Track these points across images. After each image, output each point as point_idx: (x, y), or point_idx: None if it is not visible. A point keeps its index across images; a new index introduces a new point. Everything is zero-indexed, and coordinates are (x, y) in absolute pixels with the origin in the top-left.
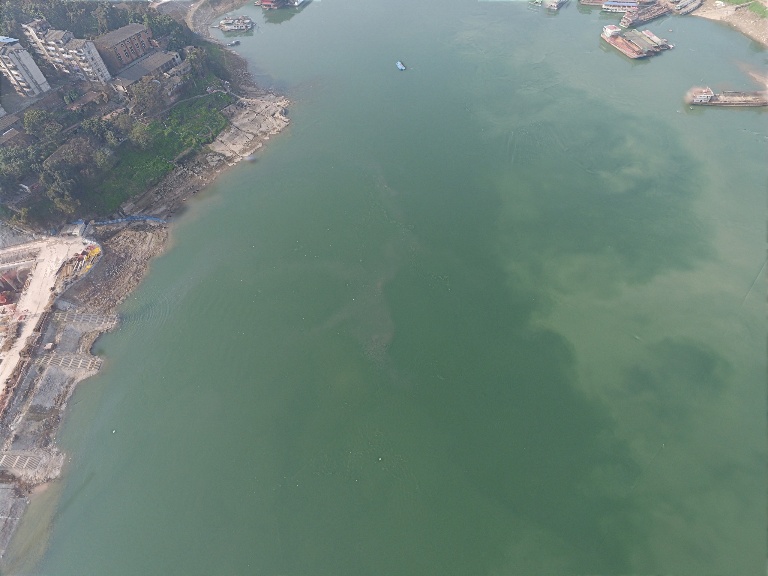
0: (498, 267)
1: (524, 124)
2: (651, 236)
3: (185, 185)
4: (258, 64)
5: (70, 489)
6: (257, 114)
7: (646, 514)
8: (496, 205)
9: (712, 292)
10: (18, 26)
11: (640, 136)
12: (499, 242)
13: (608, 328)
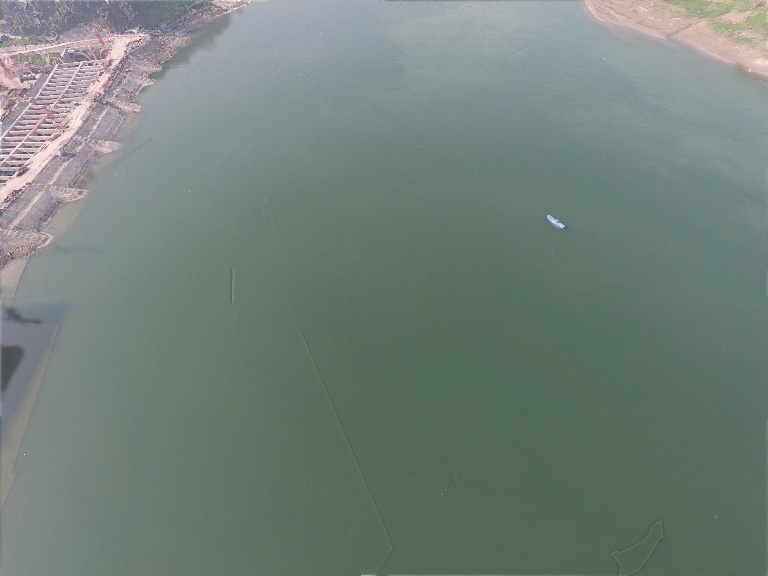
0: None
1: None
2: (470, 39)
3: (197, 20)
4: None
5: (145, 116)
6: None
7: None
8: (384, 25)
9: (491, 56)
10: None
11: None
12: (381, 40)
13: (426, 63)
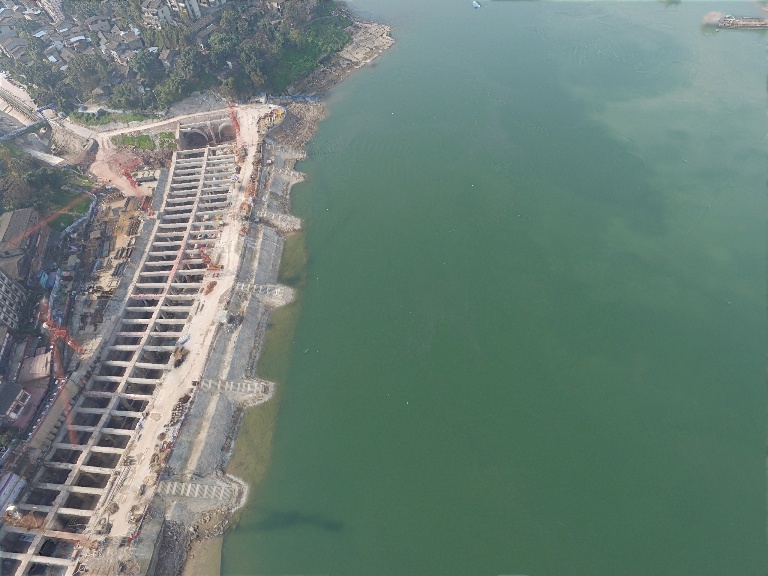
0: (579, 124)
1: (585, 41)
2: (691, 108)
3: (327, 79)
4: (355, 4)
5: (310, 235)
6: (370, 34)
7: (699, 241)
8: (572, 89)
9: (738, 138)
10: None
11: (678, 46)
12: (578, 111)
13: None
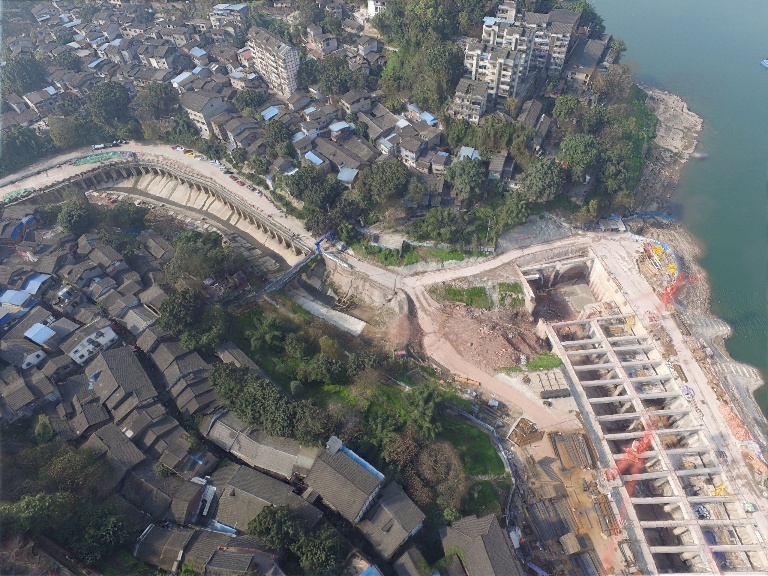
0: None
1: None
2: None
3: (659, 181)
4: None
5: None
6: None
7: None
8: None
9: None
10: (494, 7)
11: None
12: None
13: None
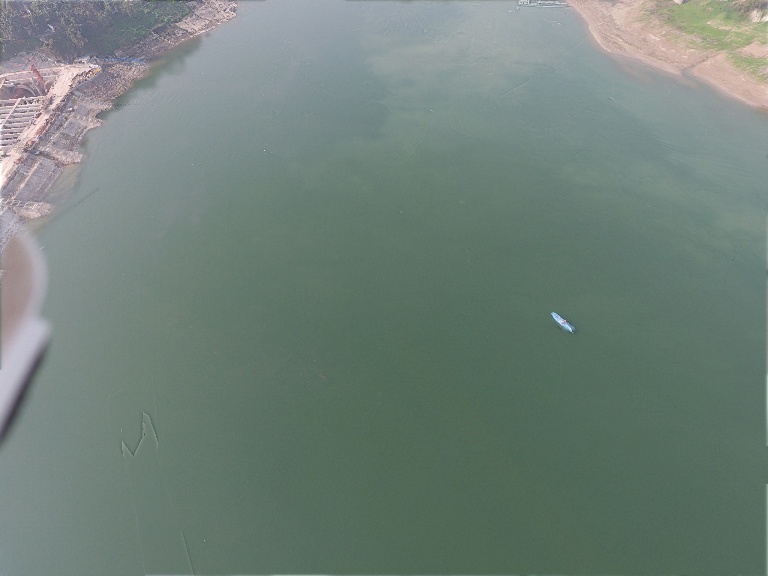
0: None
1: None
2: (462, 71)
3: (159, 45)
4: None
5: (86, 167)
6: (213, 8)
7: None
8: (366, 54)
9: (486, 93)
10: None
11: (473, 20)
12: (363, 72)
13: (413, 103)
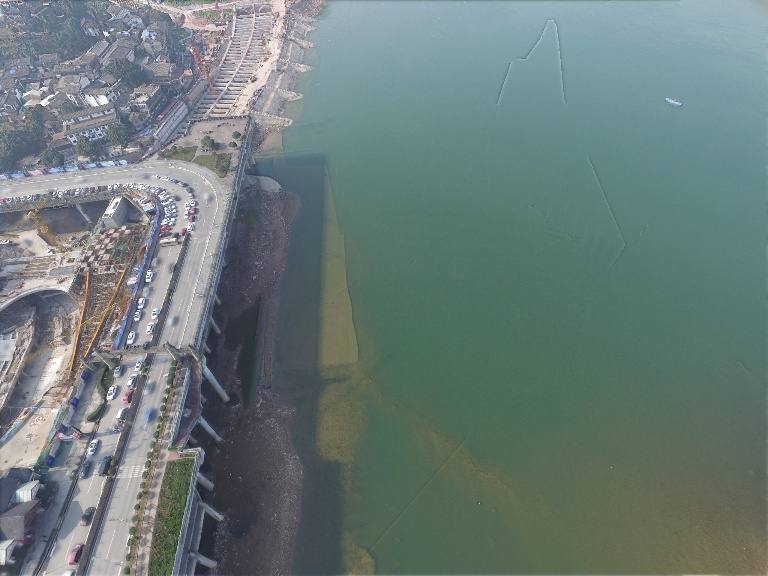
0: None
1: None
2: None
3: None
4: None
5: None
6: None
7: None
8: None
9: None
10: None
11: None
12: None
13: None
